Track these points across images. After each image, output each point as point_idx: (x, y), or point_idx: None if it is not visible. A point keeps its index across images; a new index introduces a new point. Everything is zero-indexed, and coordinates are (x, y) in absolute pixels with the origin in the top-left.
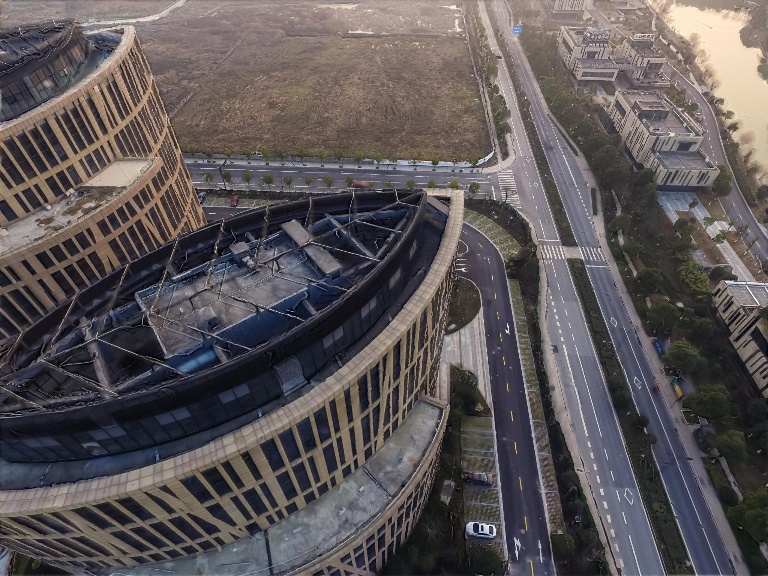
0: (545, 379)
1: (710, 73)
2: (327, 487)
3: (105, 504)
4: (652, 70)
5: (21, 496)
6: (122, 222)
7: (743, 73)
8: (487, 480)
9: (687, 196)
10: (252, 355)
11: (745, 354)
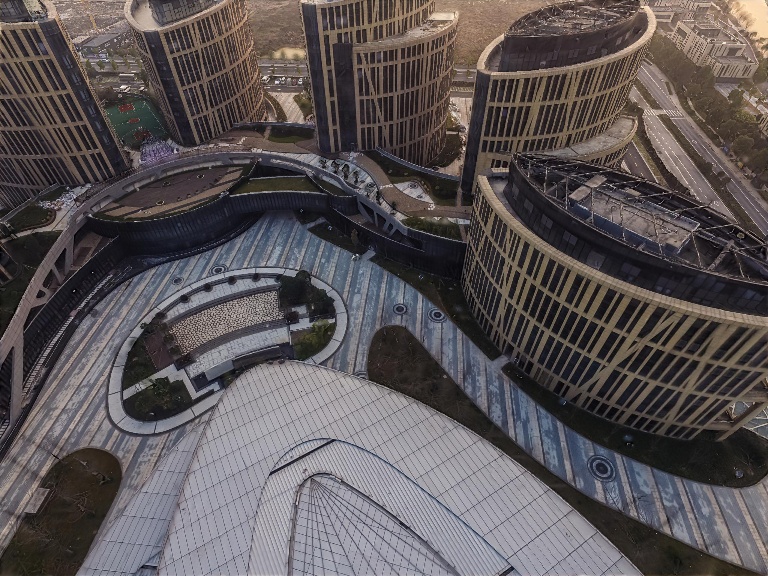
0: (659, 159)
1: (745, 17)
2: None
3: None
4: (700, 13)
5: (530, 71)
6: None
7: None
8: None
9: (734, 86)
10: (606, 28)
11: None
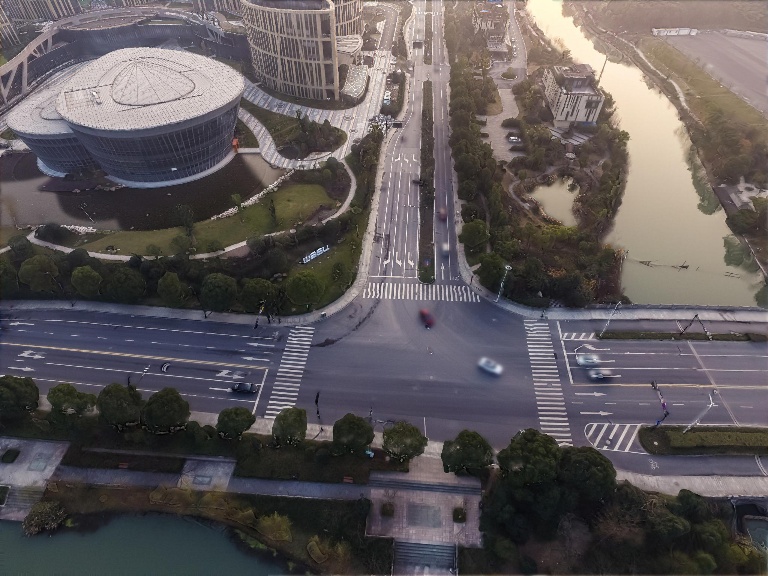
0: None
1: None
2: None
3: None
4: None
5: None
6: None
7: None
8: (375, 39)
9: None
10: None
11: None
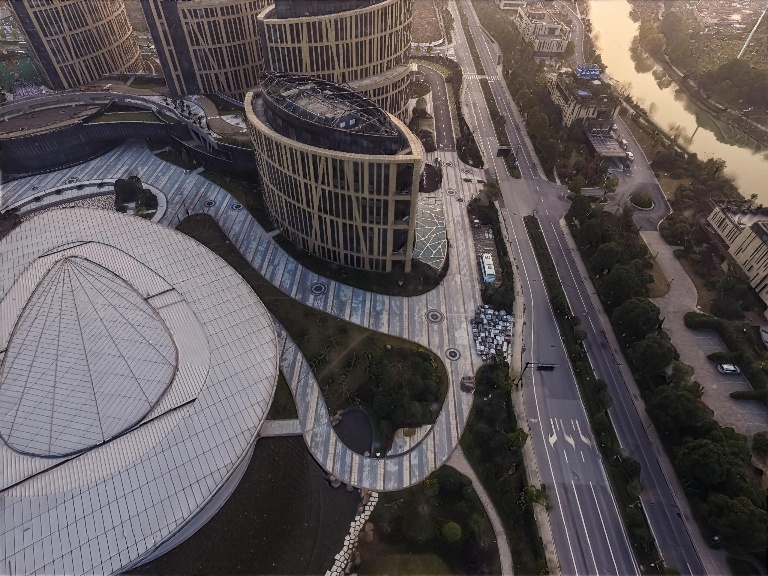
0: (459, 108)
1: None
2: (367, 73)
3: (315, 23)
4: (548, 2)
5: None
6: (273, 3)
7: (619, 16)
8: (430, 131)
9: (553, 59)
10: None
11: (554, 98)
